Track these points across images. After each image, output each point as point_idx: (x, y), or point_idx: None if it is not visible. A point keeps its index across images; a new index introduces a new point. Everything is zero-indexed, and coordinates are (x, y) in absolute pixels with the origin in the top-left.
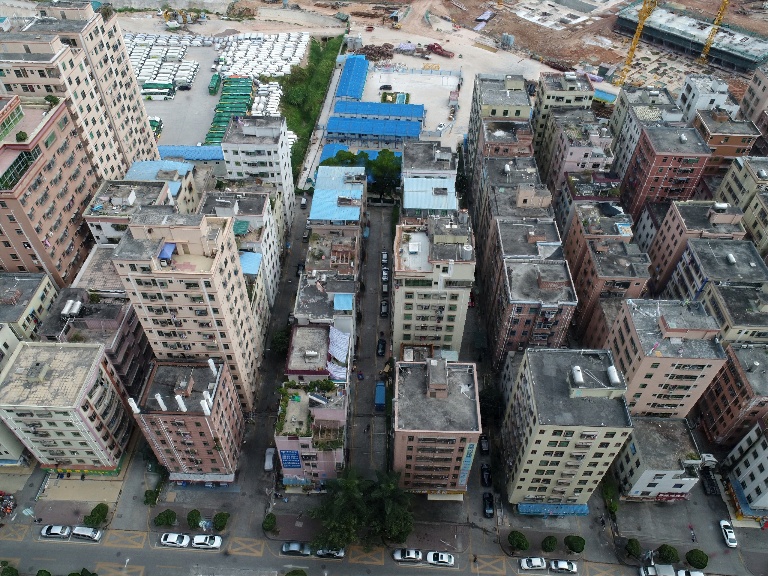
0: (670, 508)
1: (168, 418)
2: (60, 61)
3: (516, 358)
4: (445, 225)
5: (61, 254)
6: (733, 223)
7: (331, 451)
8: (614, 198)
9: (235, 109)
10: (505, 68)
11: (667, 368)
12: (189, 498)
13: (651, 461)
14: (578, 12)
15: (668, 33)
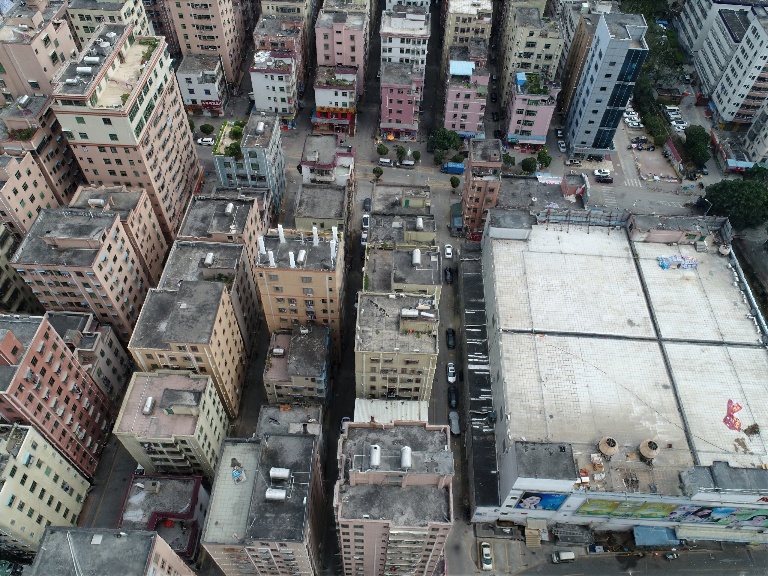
0: (219, 119)
1: None
2: None
3: None
4: None
5: None
6: None
7: None
8: None
9: None
10: None
11: (187, 7)
12: None
13: (184, 71)
14: None
15: None
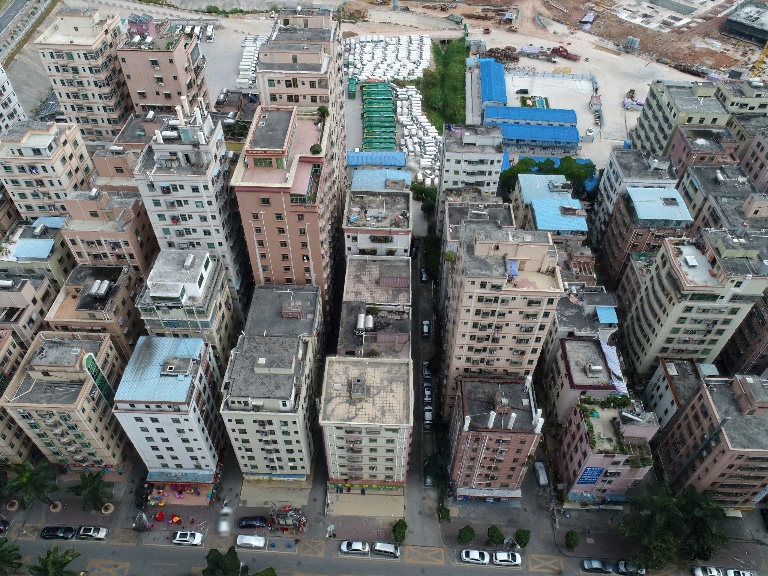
0: None
1: (496, 436)
2: (328, 71)
3: None
4: (732, 239)
5: (325, 266)
6: None
7: (638, 468)
8: None
9: (383, 114)
10: (634, 72)
11: None
12: (472, 513)
13: None
14: (679, 14)
15: None
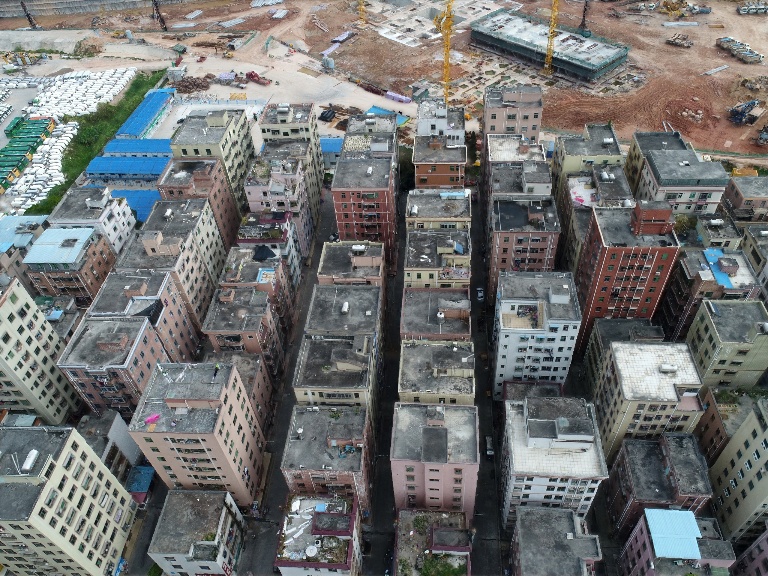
0: None
1: None
2: None
3: (89, 423)
4: None
5: None
6: (375, 265)
7: None
8: (277, 240)
9: (15, 153)
10: (317, 93)
11: (164, 442)
12: None
13: (163, 542)
14: None
15: (514, 44)
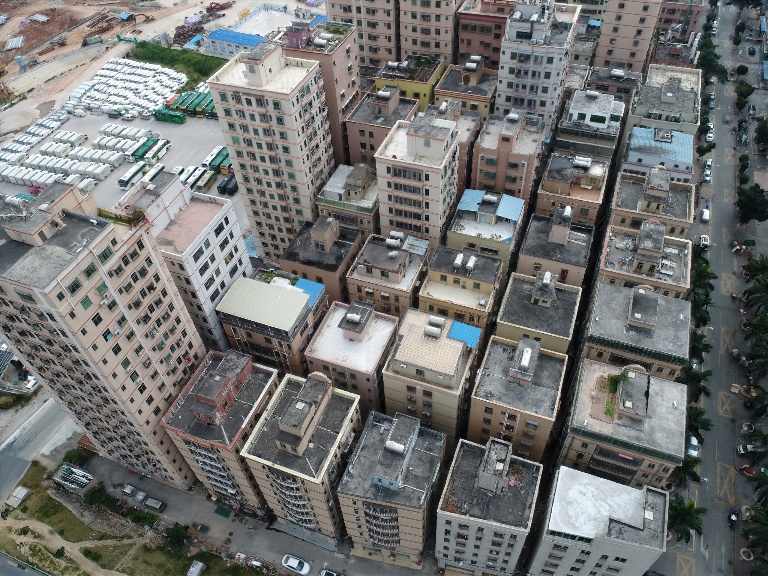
0: None
1: None
2: None
3: None
4: None
5: None
6: None
7: None
8: None
9: None
10: None
11: None
12: None
13: None
14: None
15: None
